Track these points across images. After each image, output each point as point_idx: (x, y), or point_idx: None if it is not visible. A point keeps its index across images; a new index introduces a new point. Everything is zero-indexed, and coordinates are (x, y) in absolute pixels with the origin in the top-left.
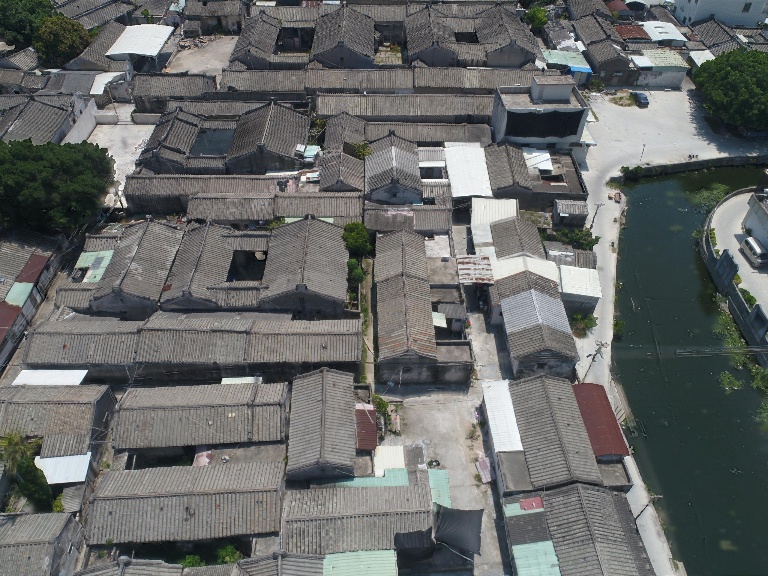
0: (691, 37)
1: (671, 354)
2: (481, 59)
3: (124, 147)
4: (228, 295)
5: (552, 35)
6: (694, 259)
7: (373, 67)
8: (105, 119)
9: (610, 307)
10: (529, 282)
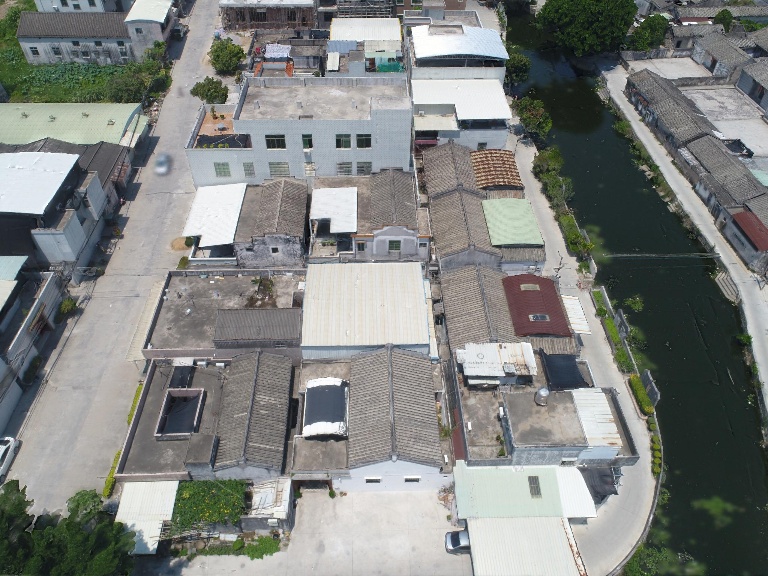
0: None
1: (686, 325)
2: None
3: None
4: None
5: None
6: (666, 447)
7: None
8: None
9: (759, 358)
10: None
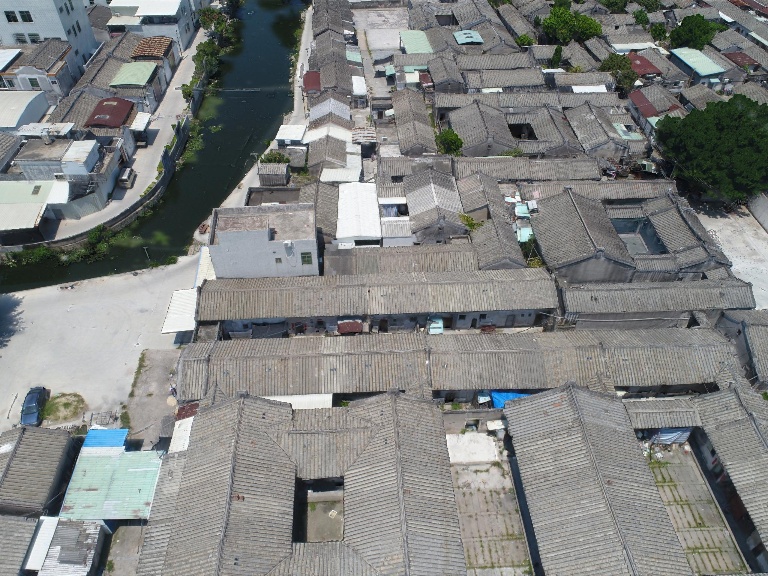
0: None
1: (241, 139)
2: (305, 409)
3: (760, 281)
4: None
5: None
6: (171, 194)
7: None
8: None
9: None
10: (331, 115)
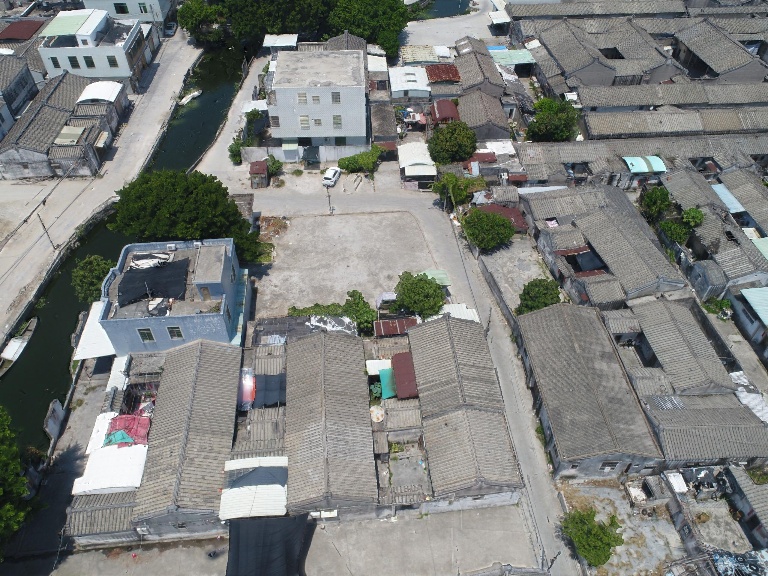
0: (375, 86)
1: None
2: None
3: None
4: None
5: (525, 90)
6: None
7: (673, 40)
8: None
9: None
10: None
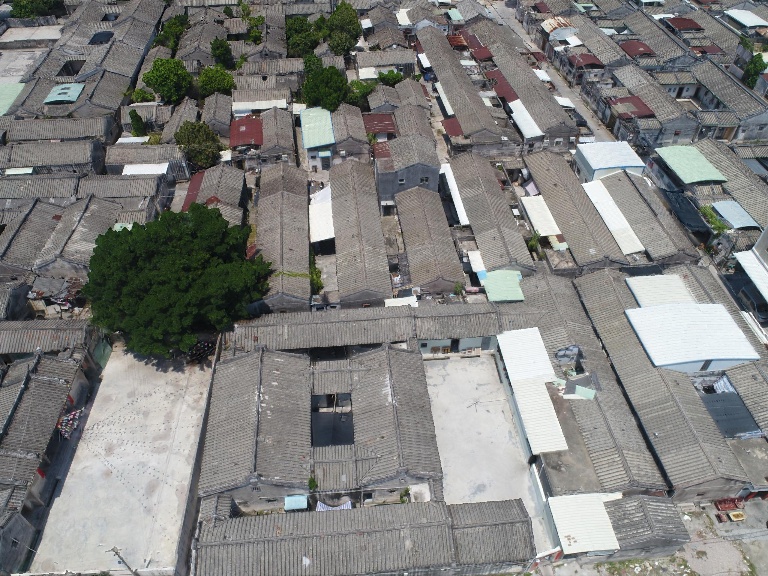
0: None
1: None
2: None
3: (125, 490)
4: (7, 209)
5: None
6: None
7: None
8: (163, 573)
9: None
10: None
